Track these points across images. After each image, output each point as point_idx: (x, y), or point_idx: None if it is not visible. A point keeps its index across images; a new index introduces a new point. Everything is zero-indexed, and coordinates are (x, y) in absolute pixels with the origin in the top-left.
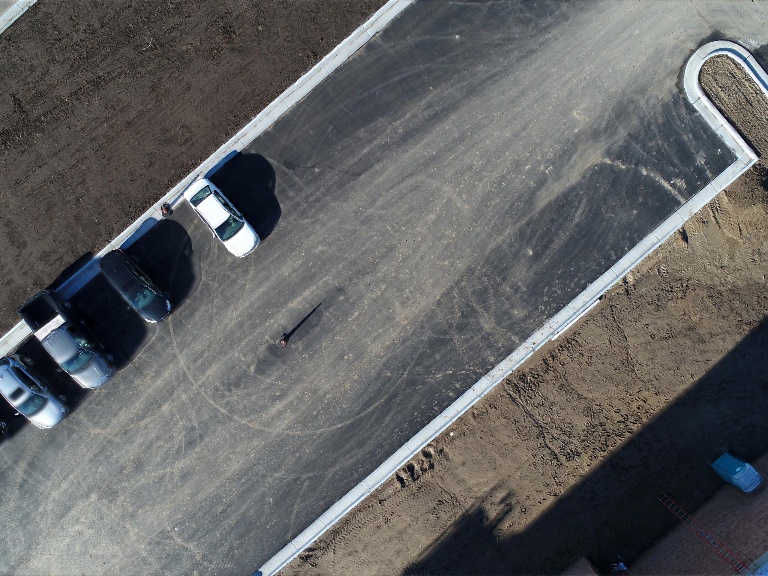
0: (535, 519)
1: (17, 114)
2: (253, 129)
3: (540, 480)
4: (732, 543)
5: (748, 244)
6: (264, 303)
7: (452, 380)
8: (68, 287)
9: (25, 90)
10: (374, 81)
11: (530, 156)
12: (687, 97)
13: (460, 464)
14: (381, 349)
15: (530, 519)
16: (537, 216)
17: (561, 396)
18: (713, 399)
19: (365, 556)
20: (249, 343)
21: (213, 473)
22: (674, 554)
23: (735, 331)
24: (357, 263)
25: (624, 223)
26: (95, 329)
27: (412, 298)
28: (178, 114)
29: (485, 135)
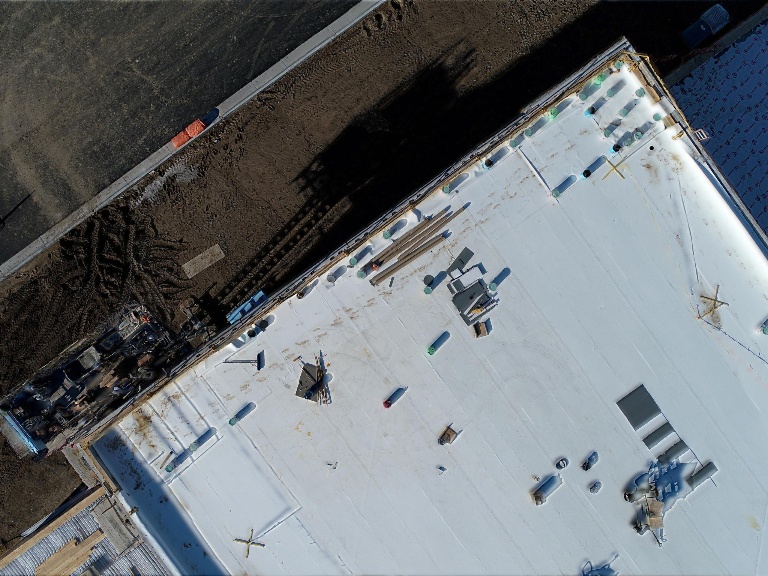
0: (499, 77)
1: None
2: None
3: (508, 37)
4: None
5: None
6: None
7: None
8: None
9: None
10: None
11: None
12: None
13: (428, 17)
14: None
15: (494, 76)
16: None
17: None
18: None
19: (325, 102)
20: None
21: (179, 6)
22: None
23: None
24: None
25: None
26: None
27: None
28: None
29: None
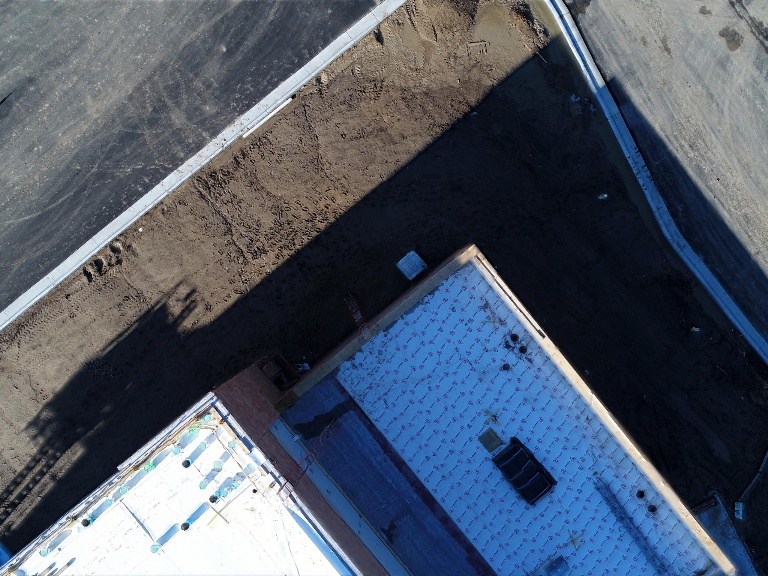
0: (220, 317)
1: None
2: None
3: (226, 277)
4: None
5: (444, 47)
6: None
7: (142, 175)
8: None
9: None
10: None
11: None
12: None
13: (147, 260)
14: (71, 142)
15: (215, 316)
16: (232, 13)
17: (250, 194)
18: (402, 200)
19: (49, 350)
20: None
21: None
22: None
23: (427, 133)
24: (49, 54)
25: (319, 22)
26: None
27: (104, 91)
28: None
29: None
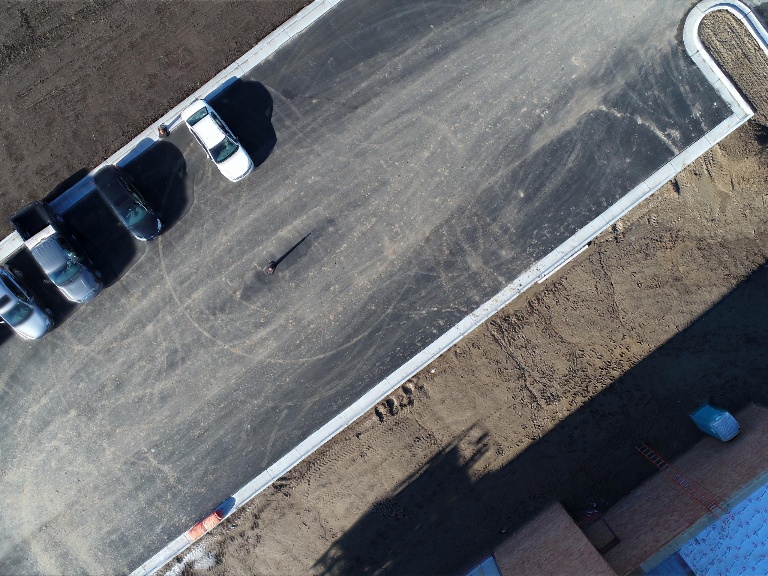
0: (512, 461)
1: (23, 29)
2: (254, 56)
3: (519, 422)
4: (707, 488)
5: (740, 199)
6: (254, 229)
7: (436, 317)
8: (62, 202)
9: (33, 6)
10: (376, 16)
11: (526, 99)
12: (685, 49)
13: (440, 402)
14: (367, 282)
15: (507, 461)
16: (530, 159)
17: (545, 339)
18: (697, 351)
19: (339, 489)
20: (237, 268)
21: (193, 396)
22: (649, 501)
23: (722, 285)
24: (349, 195)
25: (616, 171)
26: (85, 245)
27: (401, 233)
28: (181, 37)
29: (483, 76)
